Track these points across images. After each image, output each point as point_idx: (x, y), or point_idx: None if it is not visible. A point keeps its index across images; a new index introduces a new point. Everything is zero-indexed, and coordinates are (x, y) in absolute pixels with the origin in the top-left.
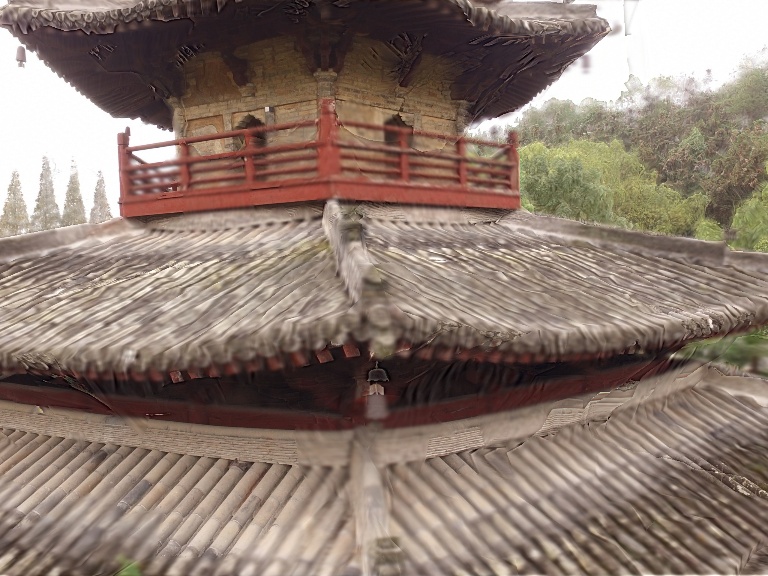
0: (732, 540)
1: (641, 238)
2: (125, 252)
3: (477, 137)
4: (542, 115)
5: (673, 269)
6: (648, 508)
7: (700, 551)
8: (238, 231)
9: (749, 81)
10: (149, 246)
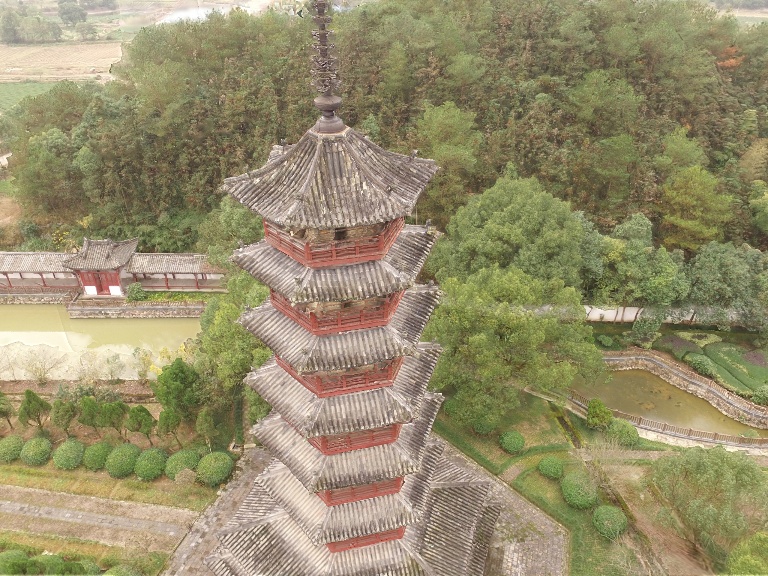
0: (481, 567)
1: (451, 484)
2: (352, 570)
3: (164, 38)
4: (233, 35)
5: (460, 495)
6: (469, 569)
7: (478, 574)
8: (374, 548)
9: (400, 66)
10: (353, 562)
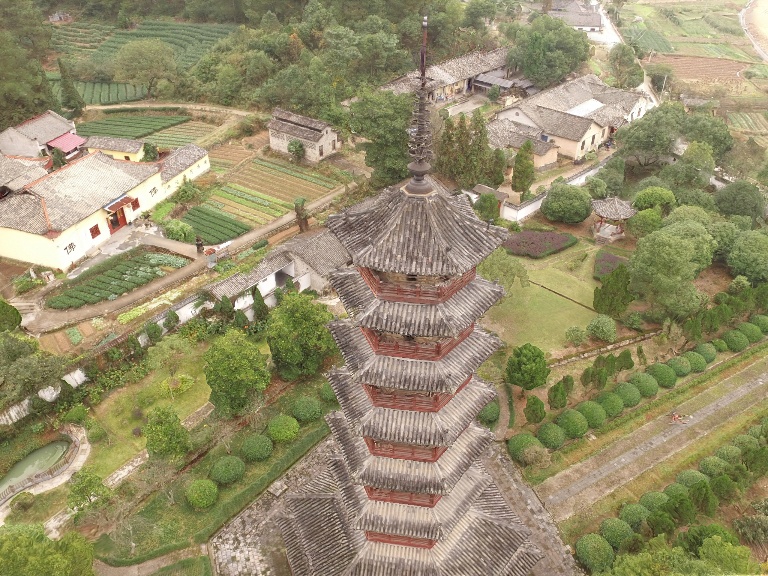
0: None
1: None
2: None
3: None
4: None
5: None
6: None
7: None
8: None
9: None
10: None
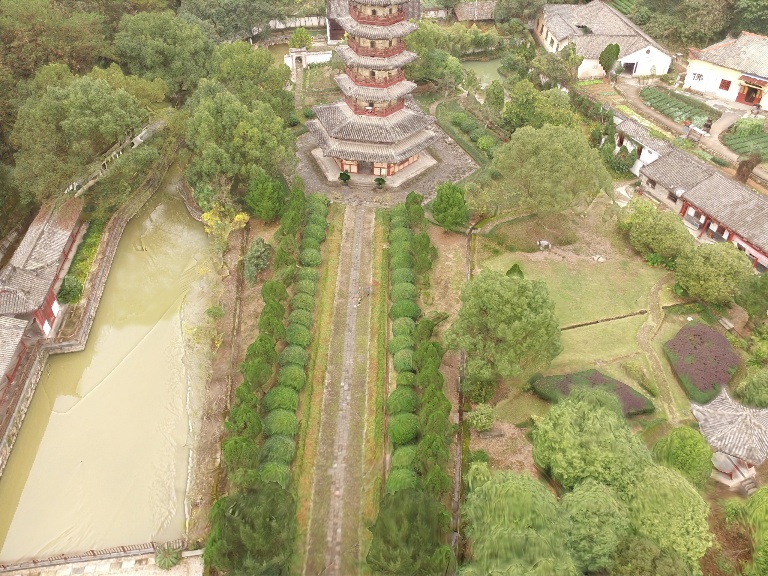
0: None
1: None
2: None
3: None
4: None
5: None
6: None
7: None
8: None
9: None
10: None
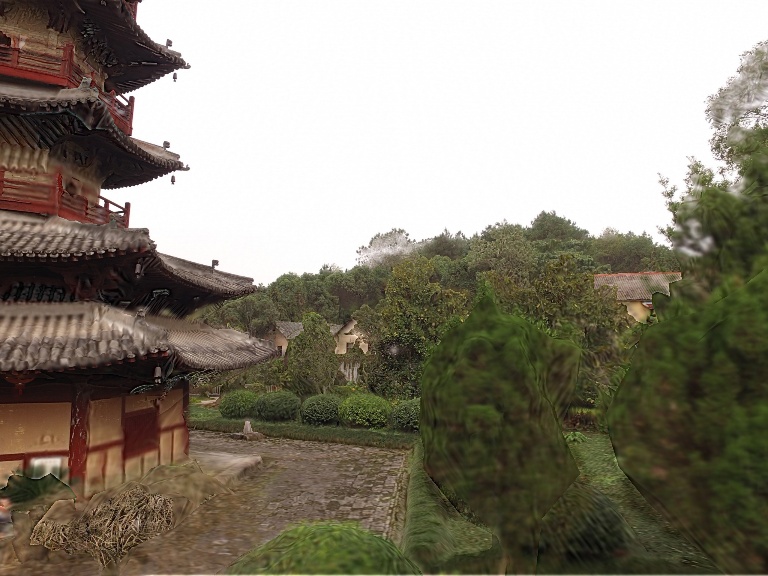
0: None
1: None
2: None
3: None
4: None
5: None
6: None
7: None
8: None
9: None
10: None
